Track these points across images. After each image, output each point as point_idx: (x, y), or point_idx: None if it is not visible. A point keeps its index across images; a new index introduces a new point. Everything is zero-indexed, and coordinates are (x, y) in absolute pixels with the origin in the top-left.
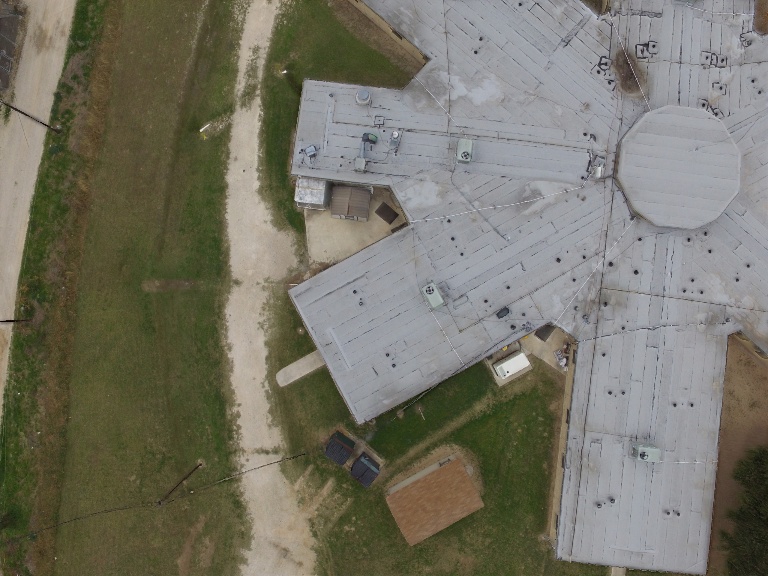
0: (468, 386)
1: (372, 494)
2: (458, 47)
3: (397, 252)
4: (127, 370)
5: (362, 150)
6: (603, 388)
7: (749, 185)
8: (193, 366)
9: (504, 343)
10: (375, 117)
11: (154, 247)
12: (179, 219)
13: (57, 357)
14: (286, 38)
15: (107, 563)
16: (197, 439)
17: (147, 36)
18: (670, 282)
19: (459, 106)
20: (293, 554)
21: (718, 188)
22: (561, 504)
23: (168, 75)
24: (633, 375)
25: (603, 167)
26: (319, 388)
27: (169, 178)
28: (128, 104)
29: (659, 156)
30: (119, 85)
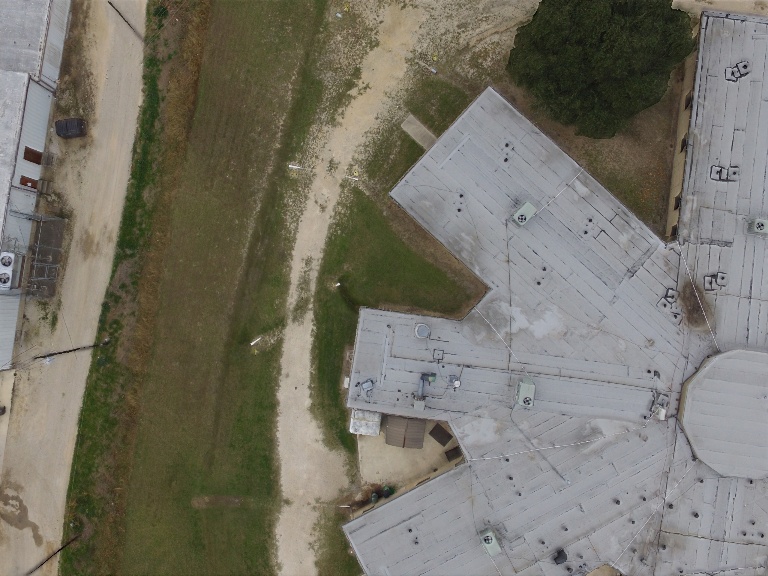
0: None
1: None
2: (521, 277)
3: (454, 490)
4: None
5: (421, 388)
6: None
7: None
8: None
9: None
10: (434, 350)
11: (204, 463)
12: (229, 435)
13: (107, 575)
14: (340, 249)
15: None
16: None
17: (197, 244)
18: (731, 525)
19: (520, 339)
20: None
21: None
22: None
23: (218, 285)
24: None
25: (666, 405)
26: None
27: (219, 393)
28: (177, 315)
29: (726, 404)
30: (168, 295)
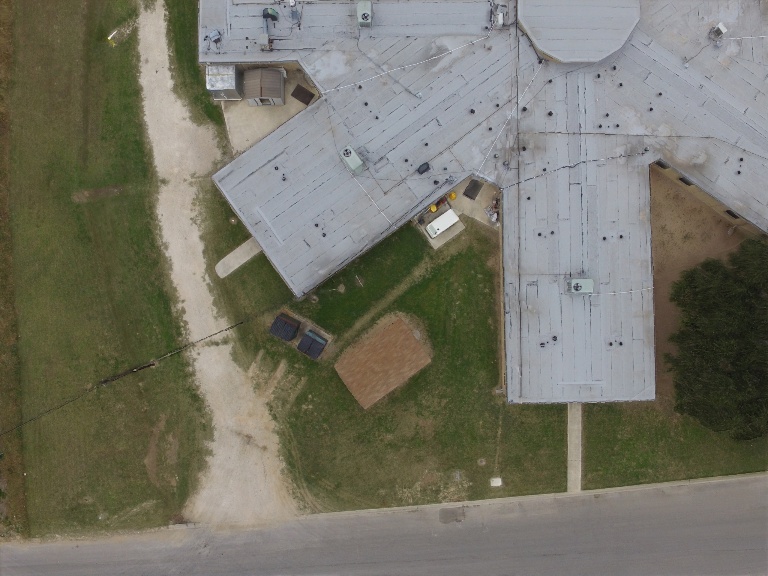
0: (404, 253)
1: (324, 370)
2: None
3: (313, 125)
4: (69, 282)
5: (265, 27)
6: (532, 231)
7: (652, 15)
8: (133, 270)
9: (430, 199)
10: None
11: (78, 159)
12: (99, 128)
13: None
14: None
15: (76, 472)
16: (147, 340)
17: None
18: (585, 119)
19: None
20: (256, 439)
21: (619, 17)
22: (505, 349)
23: None
24: (560, 214)
25: (506, 15)
26: (259, 274)
27: (84, 89)
28: (33, 22)
29: None
30: (22, 4)
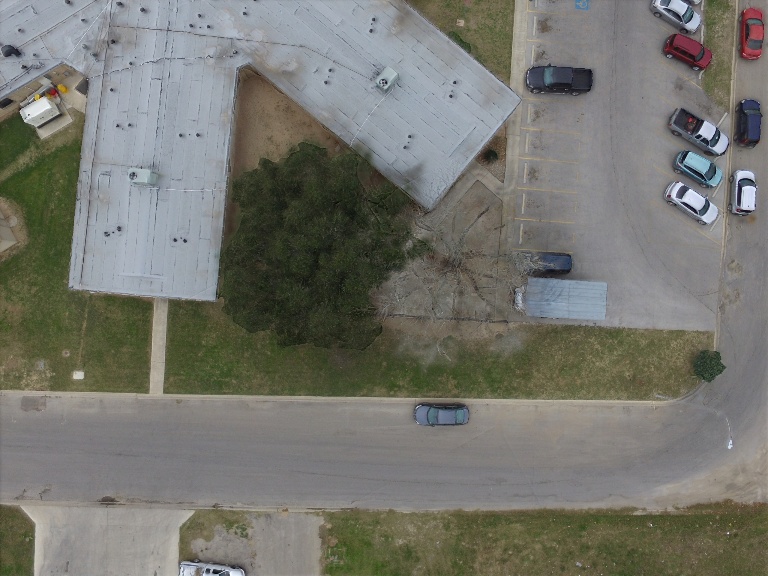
0: (12, 140)
1: None
2: None
3: None
4: None
5: None
6: (112, 122)
7: None
8: None
9: (17, 83)
10: None
11: None
12: None
13: None
14: None
15: None
16: None
17: None
18: (176, 18)
19: None
20: None
21: None
22: (73, 235)
23: None
24: (140, 108)
25: None
26: None
27: None
28: None
29: None
30: None
